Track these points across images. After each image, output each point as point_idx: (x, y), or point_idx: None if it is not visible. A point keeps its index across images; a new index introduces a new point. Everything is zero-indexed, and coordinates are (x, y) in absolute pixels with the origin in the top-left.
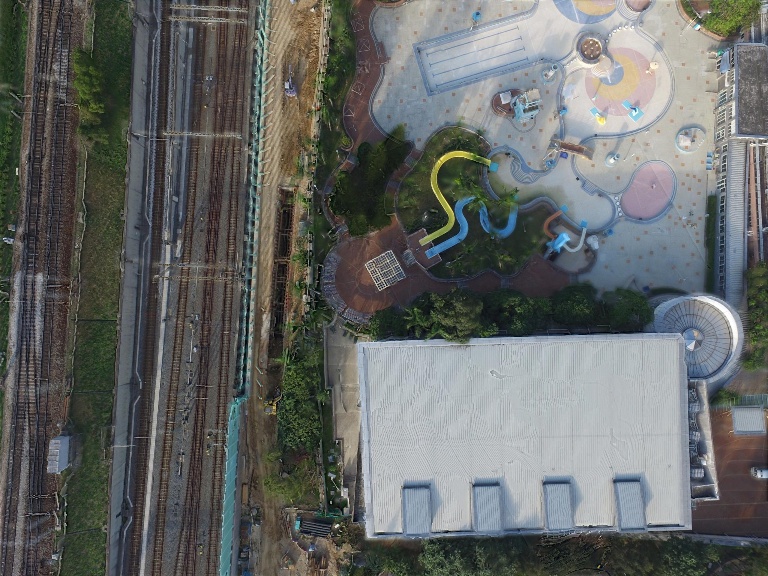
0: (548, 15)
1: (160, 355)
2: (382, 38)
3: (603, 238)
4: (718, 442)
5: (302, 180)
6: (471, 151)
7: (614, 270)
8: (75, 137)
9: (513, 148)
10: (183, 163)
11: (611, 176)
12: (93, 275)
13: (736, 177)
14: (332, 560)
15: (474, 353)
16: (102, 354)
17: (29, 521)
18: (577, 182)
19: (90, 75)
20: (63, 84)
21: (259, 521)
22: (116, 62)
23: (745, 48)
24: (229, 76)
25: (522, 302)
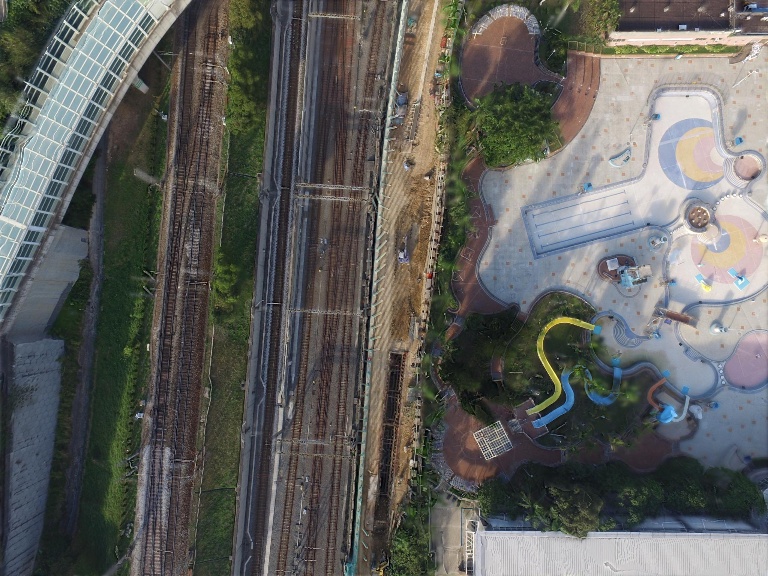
0: (655, 180)
1: (271, 516)
2: (490, 201)
3: (706, 407)
4: None
5: (412, 345)
6: (576, 317)
7: (716, 439)
8: (204, 314)
9: (617, 313)
10: (296, 325)
11: (715, 344)
12: (215, 446)
13: None
14: None
15: (589, 545)
16: (221, 523)
17: None
18: (680, 347)
19: (230, 272)
20: (194, 262)
21: None
22: (242, 237)
23: None
24: (343, 240)
25: (637, 493)
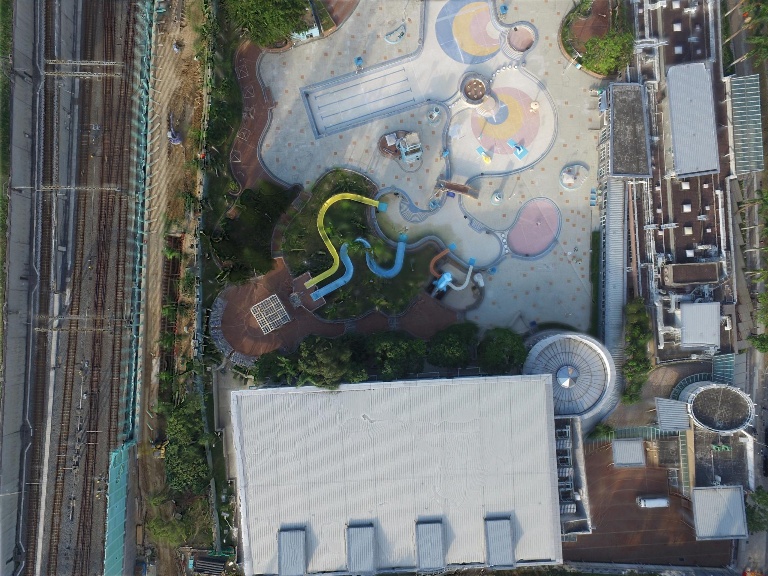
0: (433, 56)
1: (50, 402)
2: (269, 83)
3: (489, 275)
4: (594, 476)
5: (189, 226)
6: (358, 193)
7: (501, 306)
8: None
9: (400, 189)
10: (71, 212)
11: (497, 214)
12: None
13: (615, 214)
14: None
15: (346, 398)
16: None
17: None
18: (465, 220)
19: None
20: None
21: (154, 561)
22: None
23: (620, 88)
24: (115, 125)
25: (393, 347)
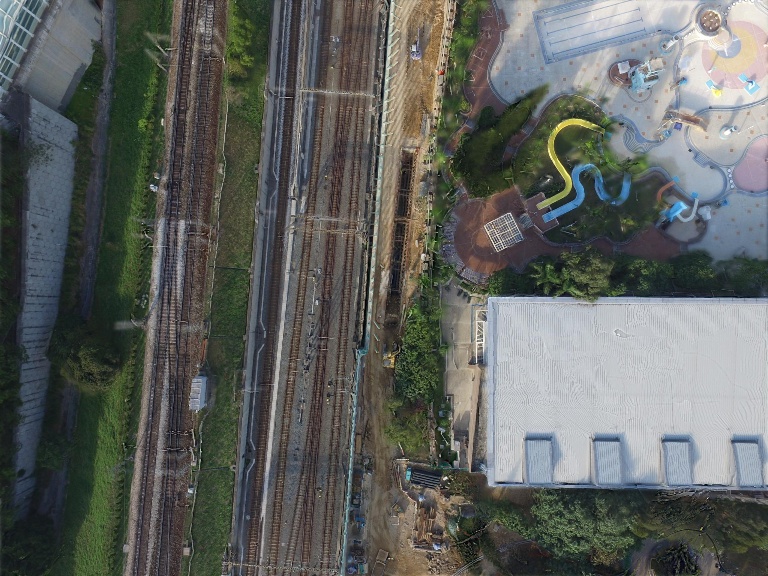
0: None
1: (284, 306)
2: (502, 5)
3: (714, 209)
4: None
5: (423, 142)
6: (587, 119)
7: (724, 241)
8: (218, 91)
9: (628, 118)
10: (309, 122)
11: (724, 148)
12: (229, 225)
13: None
14: (440, 511)
15: (600, 312)
16: (235, 301)
17: (168, 455)
18: (689, 154)
19: (246, 28)
20: (208, 39)
21: (371, 470)
22: (255, 20)
23: None
24: (355, 38)
25: (647, 264)
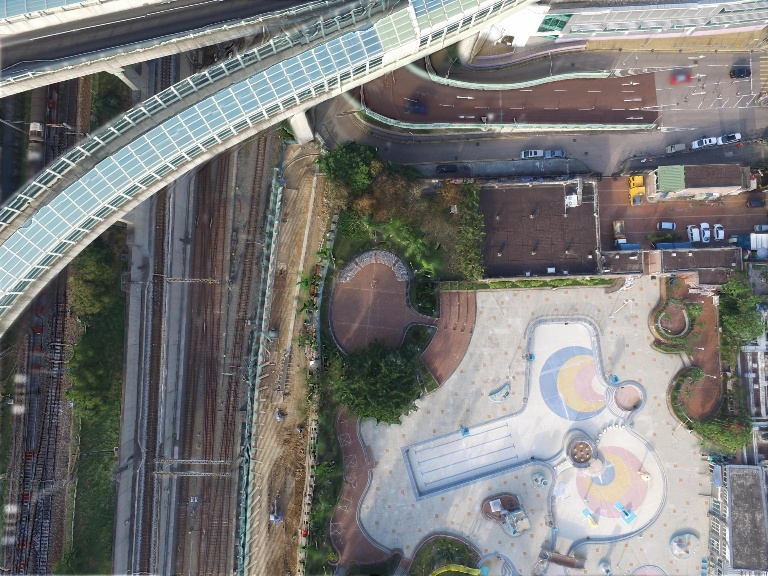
0: (537, 412)
1: None
2: (370, 442)
3: None
4: None
5: None
6: (461, 562)
7: None
8: None
9: (504, 555)
10: None
11: None
12: None
13: None
14: None
15: None
16: None
17: None
18: None
19: None
20: (43, 556)
21: None
22: (98, 518)
23: (738, 470)
24: (214, 497)
25: None
